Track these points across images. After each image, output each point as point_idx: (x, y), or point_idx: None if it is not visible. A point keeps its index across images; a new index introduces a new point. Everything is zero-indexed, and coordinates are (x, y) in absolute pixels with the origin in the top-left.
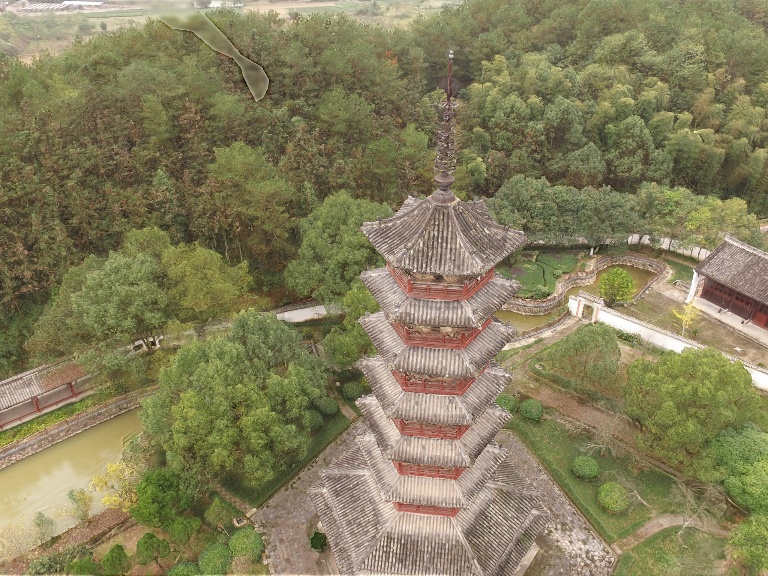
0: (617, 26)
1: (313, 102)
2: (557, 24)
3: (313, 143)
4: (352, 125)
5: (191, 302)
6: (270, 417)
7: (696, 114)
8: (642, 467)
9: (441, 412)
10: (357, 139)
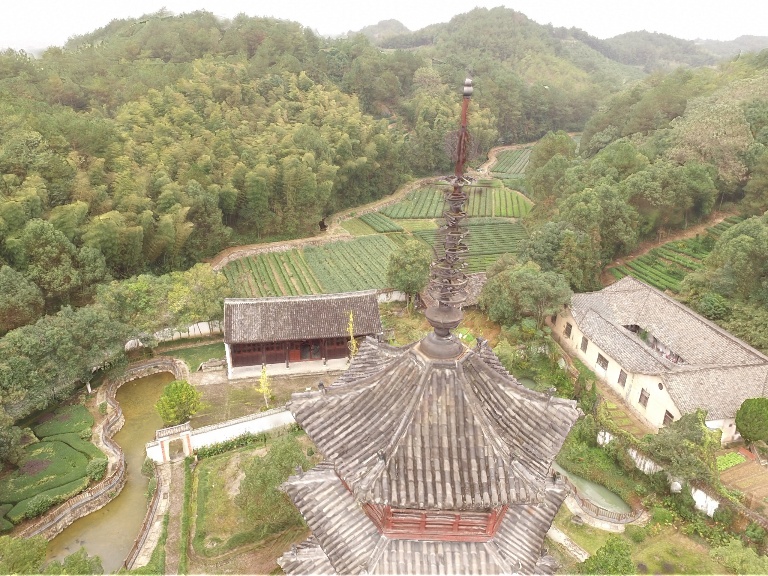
0: None
1: None
2: None
3: None
4: None
5: None
6: None
7: (82, 201)
8: None
9: None
10: None
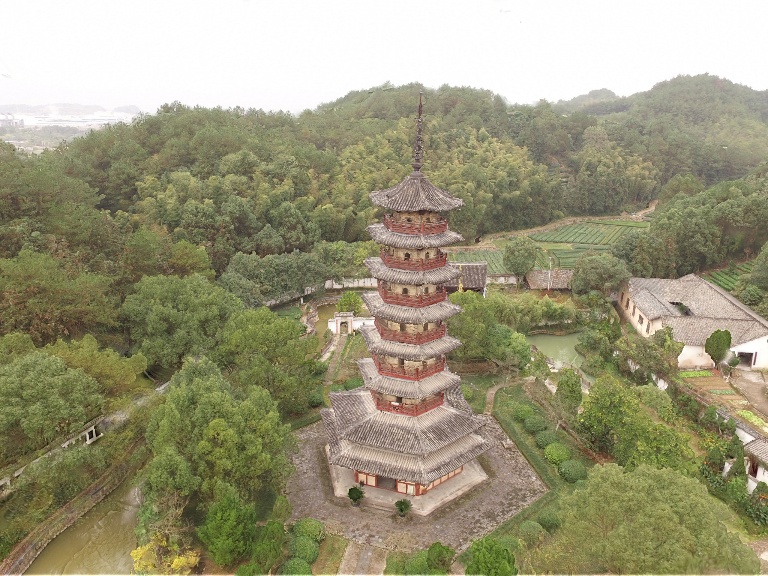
0: (223, 150)
1: (37, 219)
2: (175, 152)
3: (68, 252)
4: (94, 232)
5: (123, 375)
6: (277, 418)
7: None
8: None
9: (442, 312)
10: (100, 245)
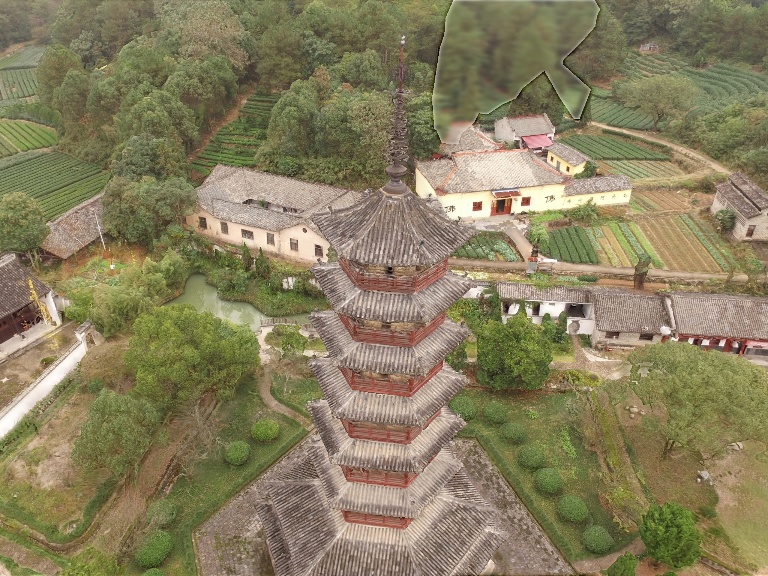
0: None
1: None
2: None
3: None
4: None
5: None
6: None
7: None
8: (217, 422)
9: None
10: None
